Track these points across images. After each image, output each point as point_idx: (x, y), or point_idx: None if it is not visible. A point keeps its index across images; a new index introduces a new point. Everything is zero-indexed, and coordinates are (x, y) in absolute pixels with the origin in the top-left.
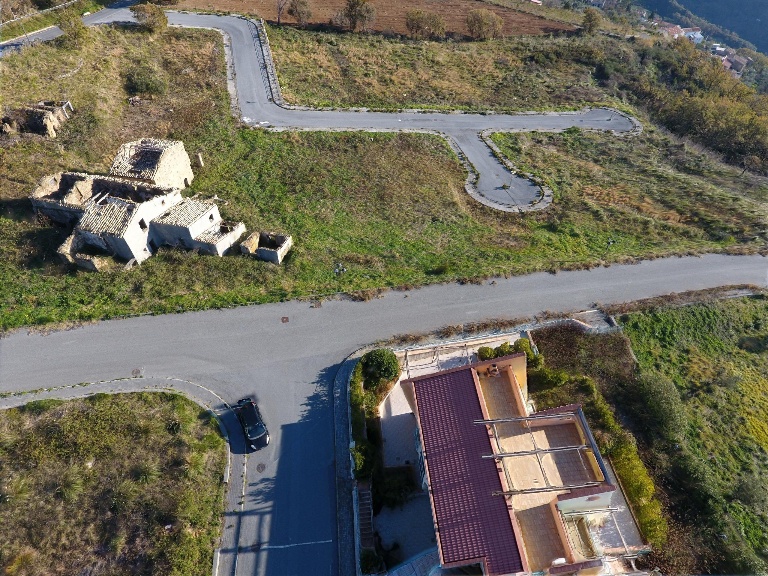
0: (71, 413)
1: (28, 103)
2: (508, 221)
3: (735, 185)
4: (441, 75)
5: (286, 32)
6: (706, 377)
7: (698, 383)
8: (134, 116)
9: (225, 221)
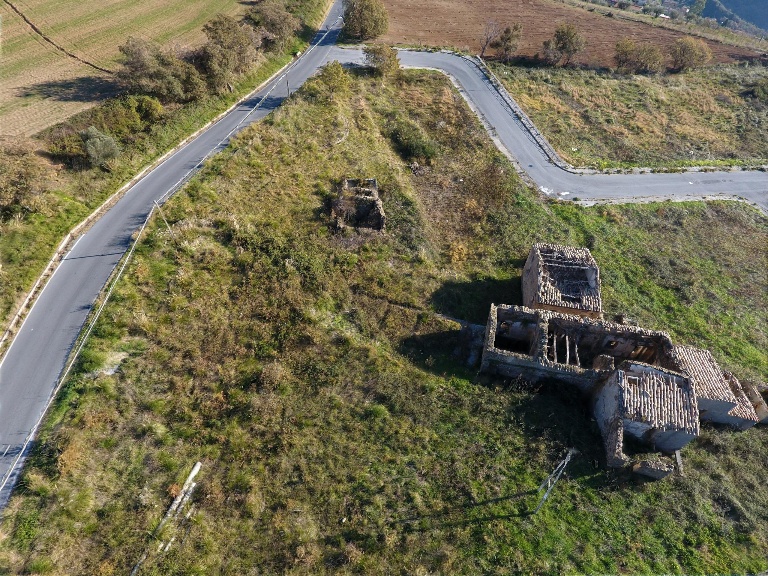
0: None
1: (328, 181)
2: None
3: None
4: (678, 118)
5: (497, 69)
6: None
7: None
8: (426, 190)
9: None
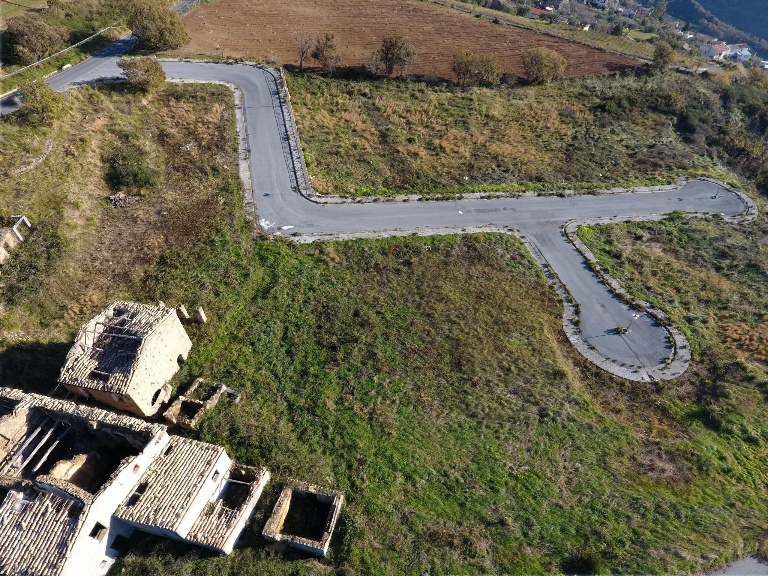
0: None
1: None
2: (639, 399)
3: None
4: (500, 136)
5: (310, 82)
6: None
7: None
8: (115, 224)
9: (237, 465)
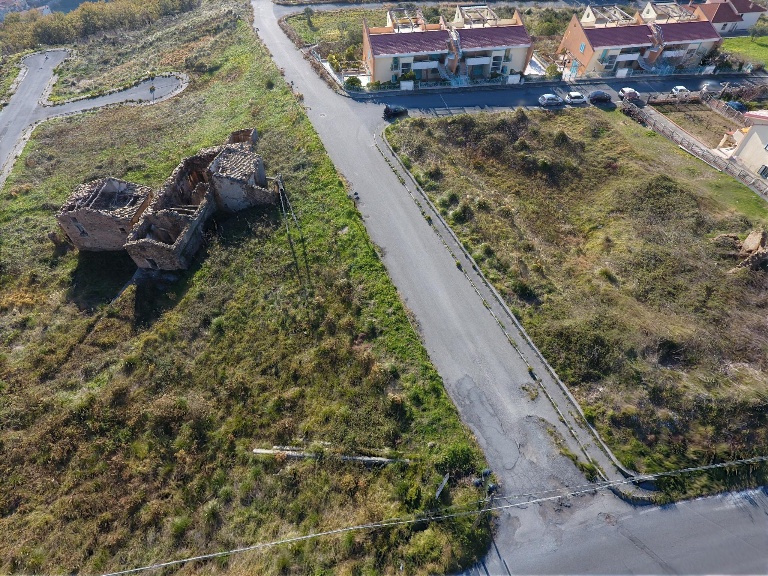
0: (409, 148)
1: None
2: (198, 87)
3: (172, 23)
4: None
5: None
6: (337, 37)
7: (341, 38)
8: None
9: None
